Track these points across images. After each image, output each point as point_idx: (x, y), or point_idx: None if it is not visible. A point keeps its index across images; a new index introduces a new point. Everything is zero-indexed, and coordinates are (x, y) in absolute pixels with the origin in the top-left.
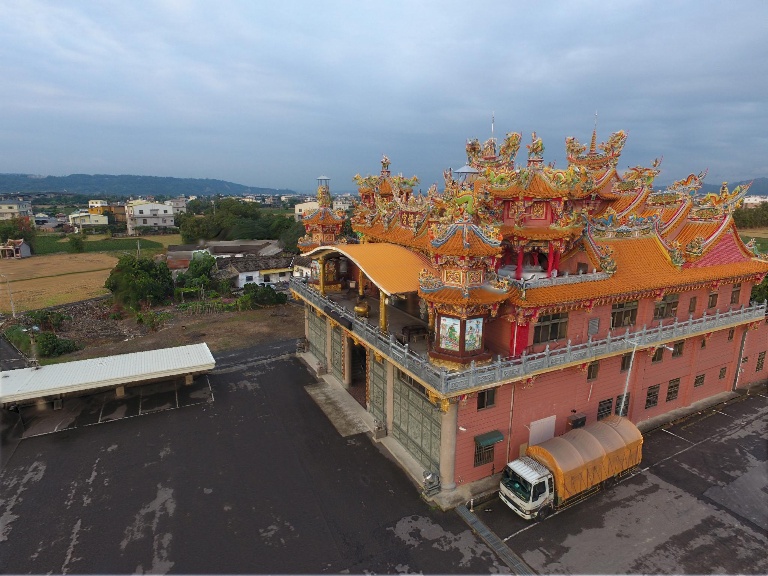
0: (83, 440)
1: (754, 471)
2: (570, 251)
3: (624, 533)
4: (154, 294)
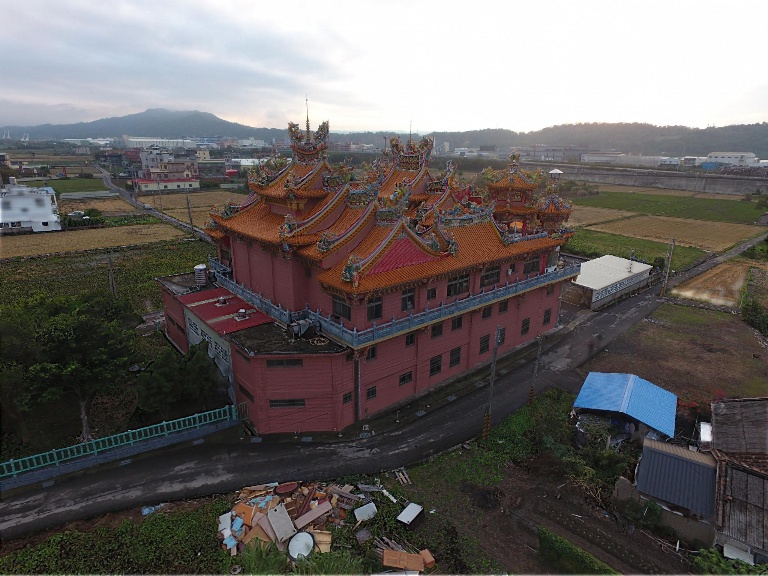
0: None
1: None
2: None
3: None
4: None
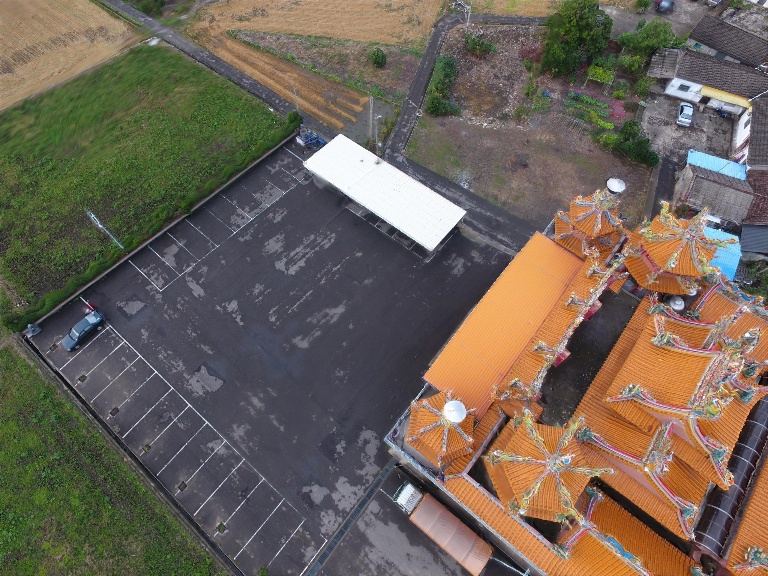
0: (358, 235)
1: None
2: (583, 510)
3: (411, 558)
4: (560, 68)
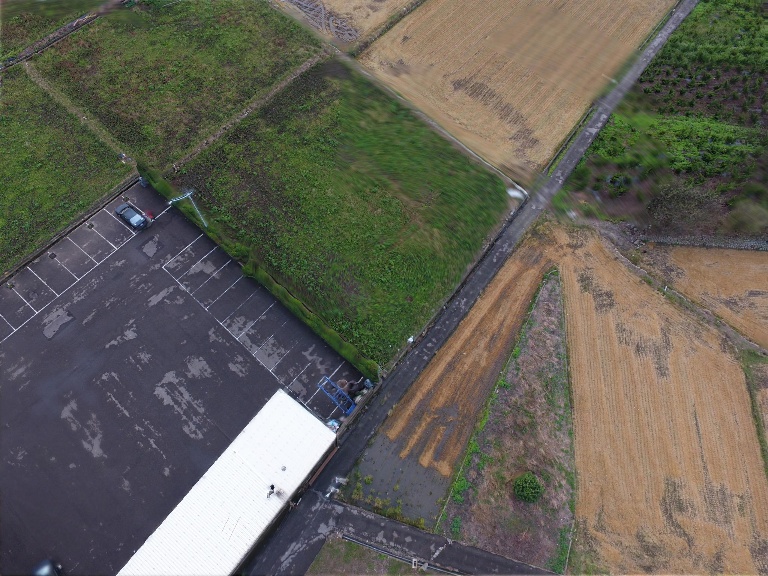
0: (195, 469)
1: None
2: None
3: None
4: None
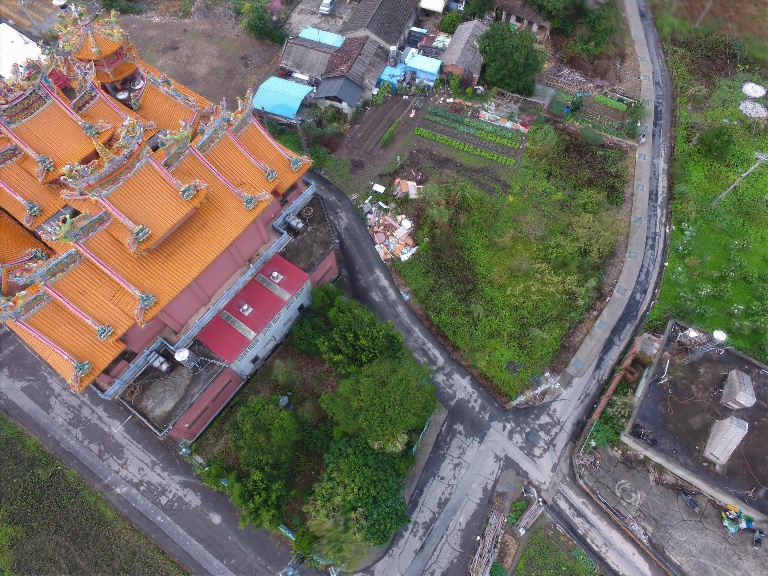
0: None
1: (8, 382)
2: None
3: None
4: None
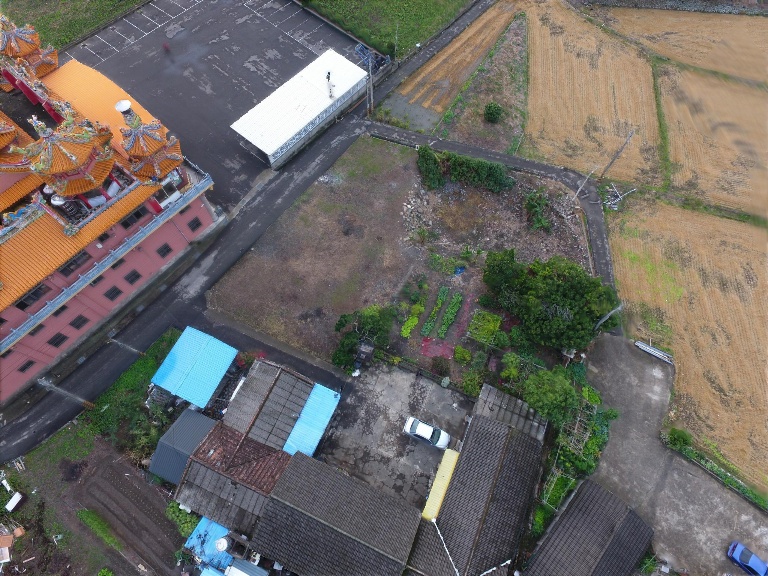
0: None
1: None
2: None
3: None
4: (487, 276)
